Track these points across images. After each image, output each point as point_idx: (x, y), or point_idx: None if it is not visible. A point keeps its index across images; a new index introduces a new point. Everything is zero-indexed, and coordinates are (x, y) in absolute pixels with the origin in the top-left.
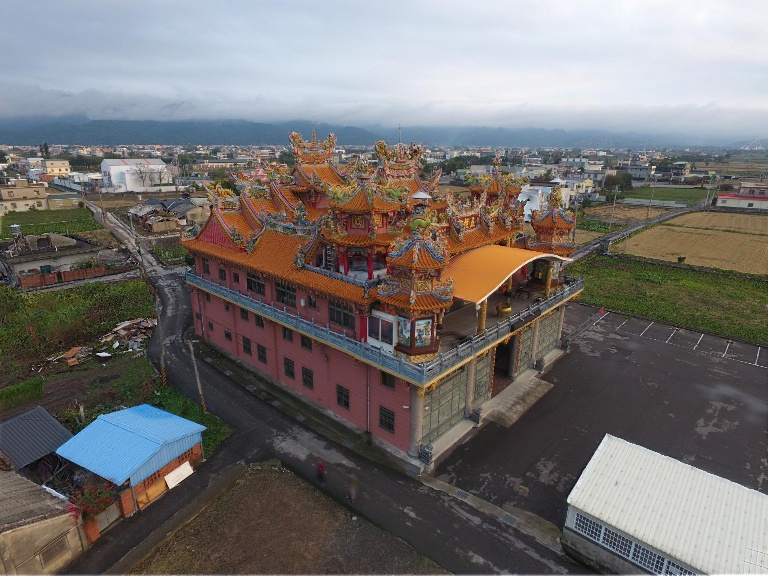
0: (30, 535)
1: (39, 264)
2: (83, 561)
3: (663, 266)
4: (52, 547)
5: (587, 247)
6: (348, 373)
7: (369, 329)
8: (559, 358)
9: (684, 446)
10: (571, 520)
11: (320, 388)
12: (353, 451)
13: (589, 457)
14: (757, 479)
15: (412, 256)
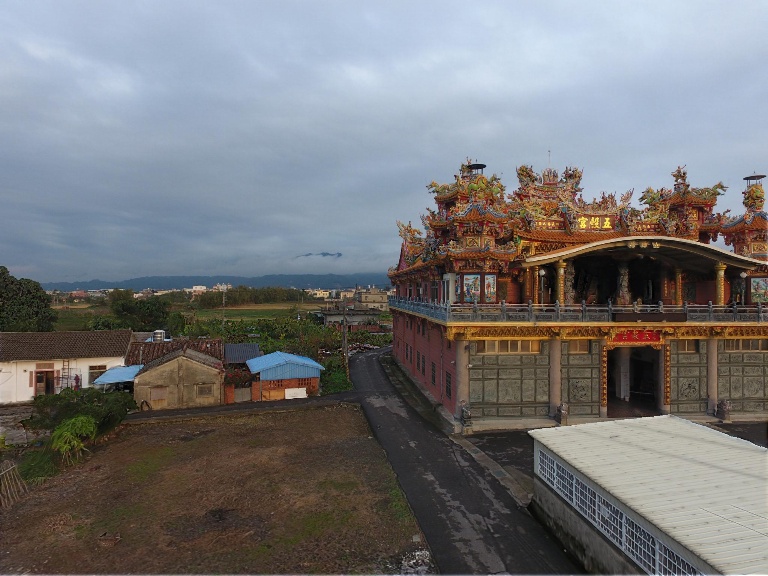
0: (195, 370)
1: (341, 318)
2: (216, 407)
3: None
4: (205, 387)
5: None
6: (435, 346)
7: (443, 296)
8: None
9: None
10: (537, 462)
11: (426, 371)
12: (417, 412)
13: None
14: None
15: (455, 210)
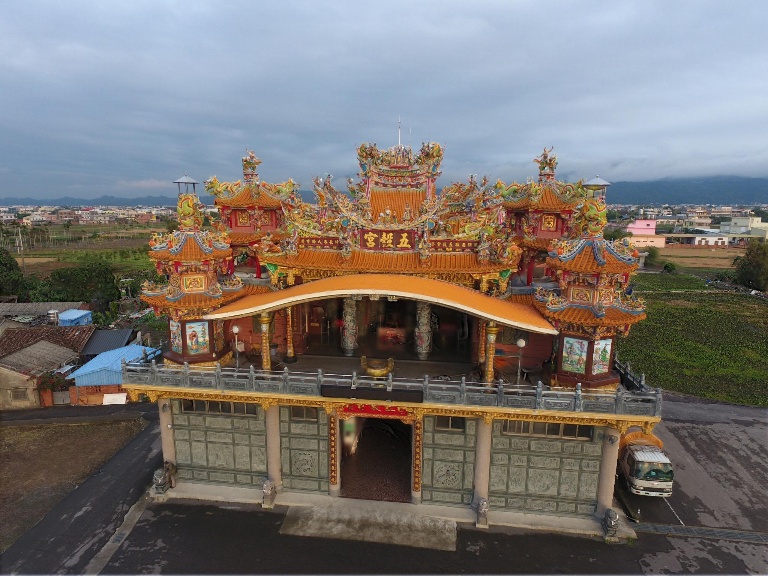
0: (6, 375)
1: None
2: (28, 411)
3: None
4: (19, 391)
5: None
6: None
7: None
8: (567, 534)
9: None
10: None
11: None
12: None
13: None
14: None
15: None
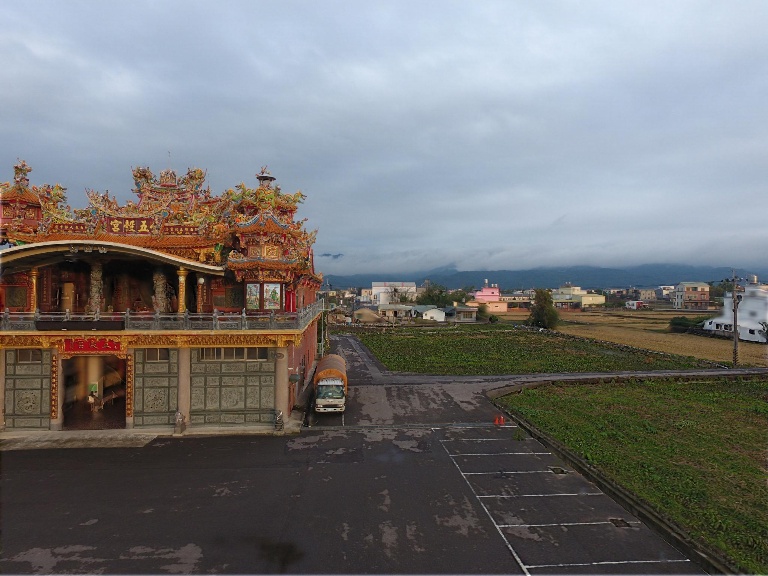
0: None
1: None
2: None
3: None
4: None
5: None
6: None
7: None
8: (246, 434)
9: None
10: None
11: None
12: None
13: None
14: None
15: None
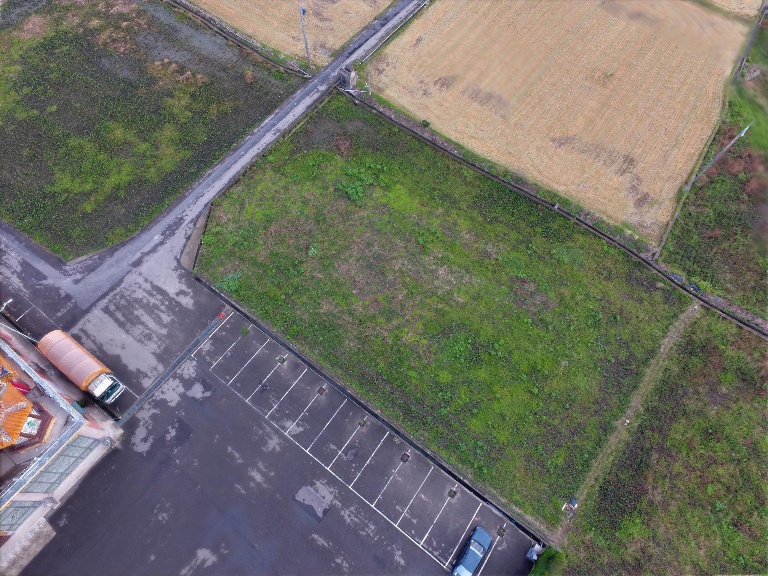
0: None
1: None
2: None
3: (403, 131)
4: None
5: (331, 69)
6: None
7: None
8: (96, 464)
9: None
10: None
11: None
12: None
13: None
14: None
15: None
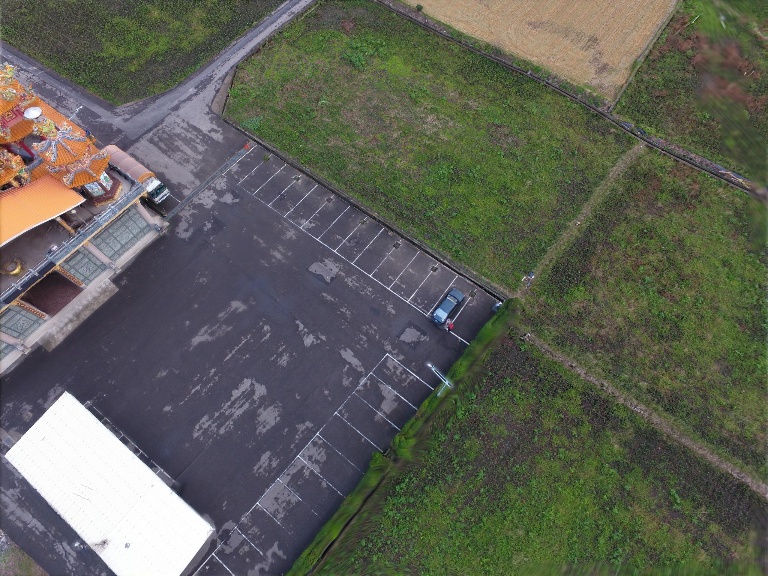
0: None
1: None
2: None
3: (400, 16)
4: None
5: None
6: None
7: None
8: (148, 245)
9: (169, 360)
10: None
11: None
12: None
13: (91, 380)
14: (191, 391)
15: None
